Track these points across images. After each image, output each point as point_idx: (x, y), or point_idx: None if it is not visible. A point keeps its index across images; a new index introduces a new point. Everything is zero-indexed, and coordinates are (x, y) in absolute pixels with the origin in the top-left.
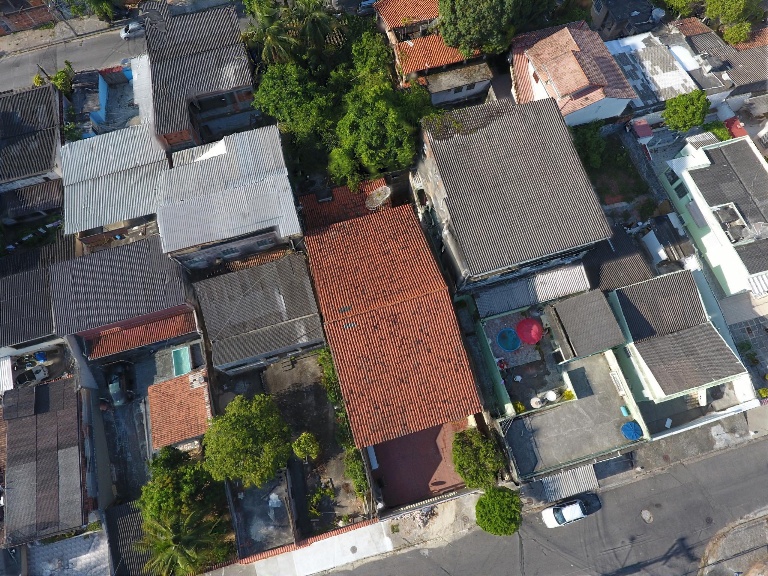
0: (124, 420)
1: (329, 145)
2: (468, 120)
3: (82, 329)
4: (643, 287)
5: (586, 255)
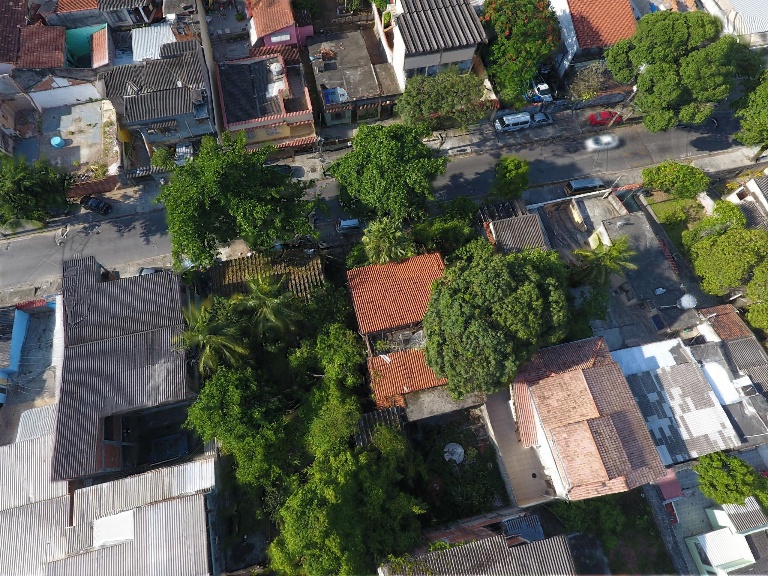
0: None
1: (273, 512)
2: (448, 571)
3: None
4: None
5: None
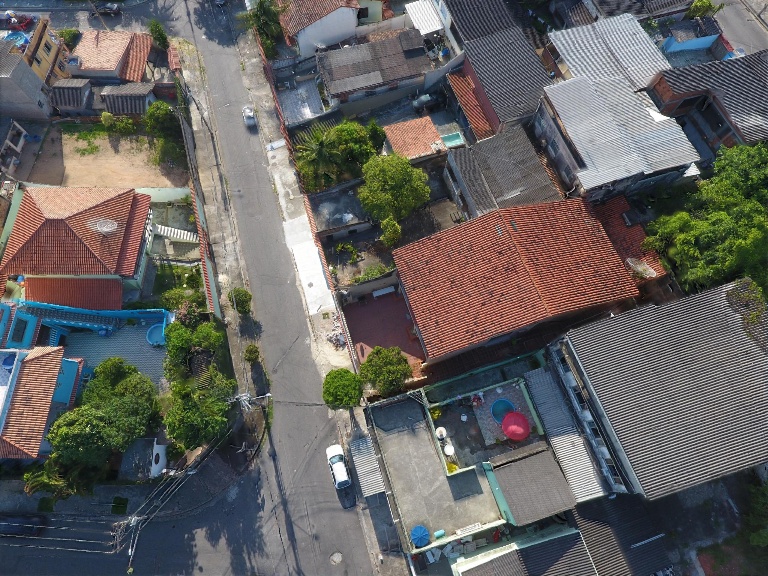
0: (402, 112)
1: (692, 216)
2: (765, 330)
3: (470, 58)
4: (589, 570)
5: (619, 508)
